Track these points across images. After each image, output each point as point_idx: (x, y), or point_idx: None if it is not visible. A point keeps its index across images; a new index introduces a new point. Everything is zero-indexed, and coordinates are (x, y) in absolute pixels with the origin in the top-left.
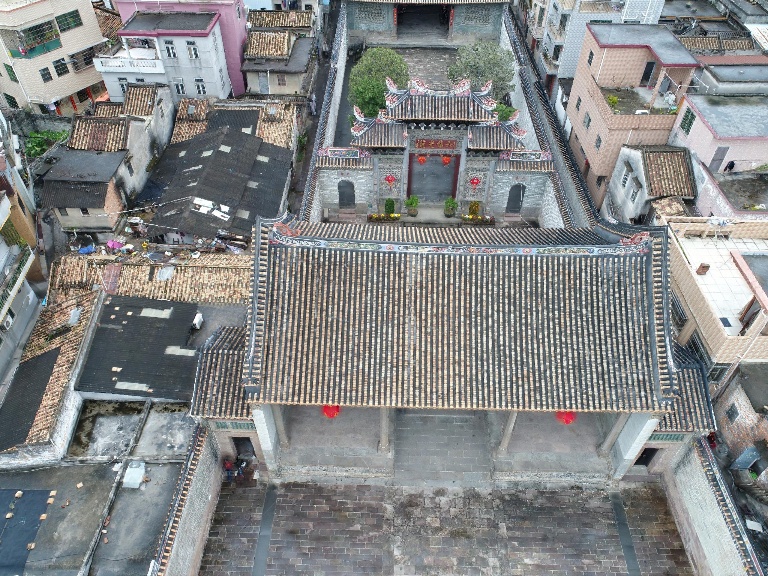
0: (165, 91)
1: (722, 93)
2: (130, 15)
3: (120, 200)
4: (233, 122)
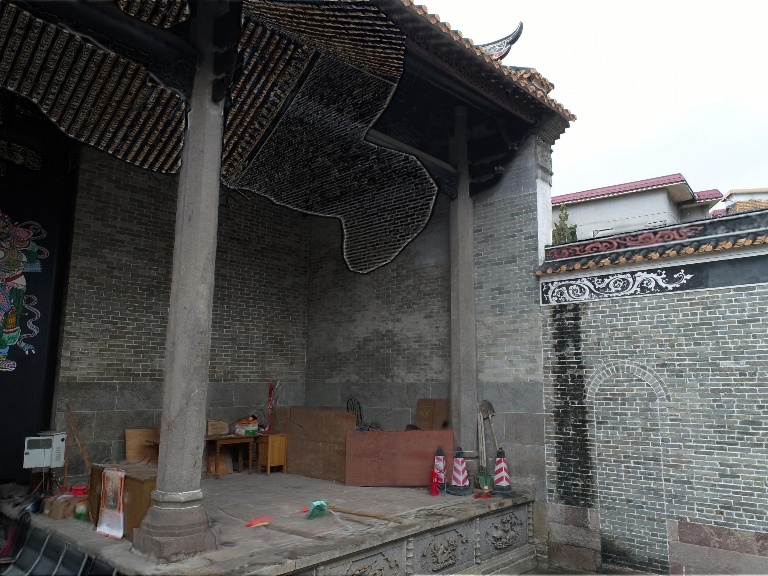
0: None
1: None
2: None
3: None
4: None
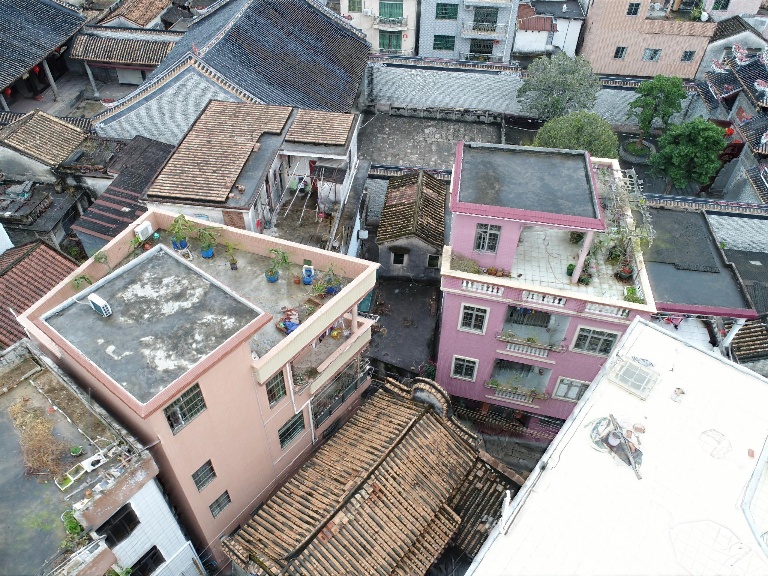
0: None
1: None
2: None
3: None
4: None
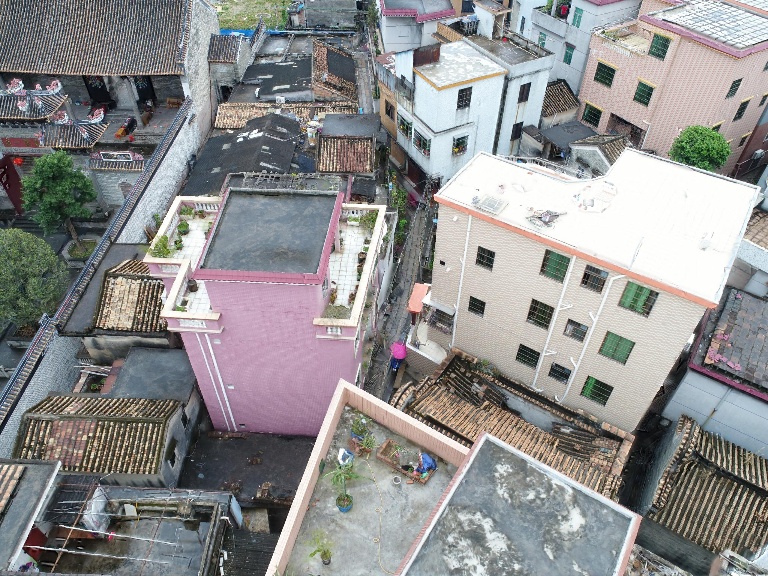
0: None
1: None
2: None
3: None
4: None
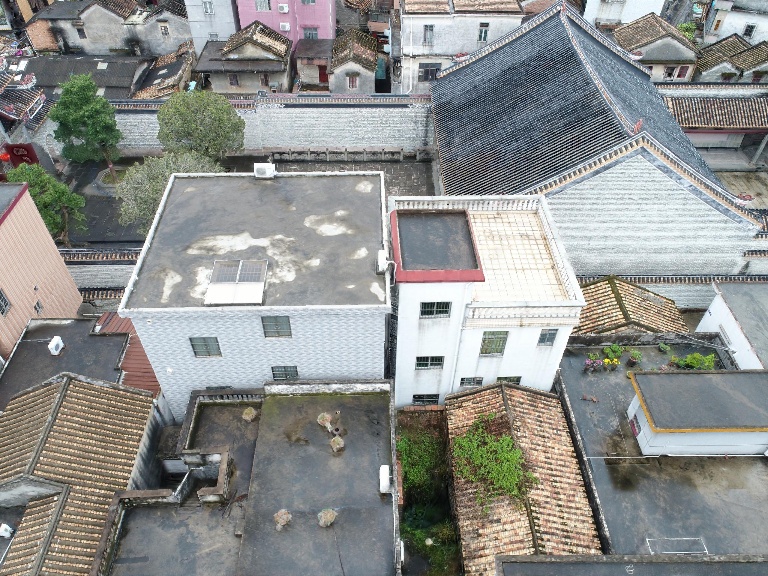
0: (182, 20)
1: None
2: None
3: (56, 41)
4: None
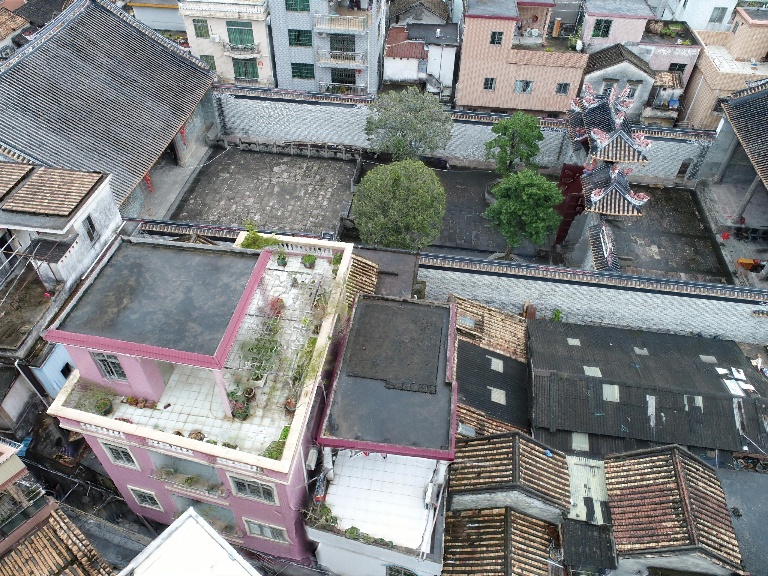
0: None
1: (583, 1)
2: (293, 471)
3: None
4: (481, 379)
